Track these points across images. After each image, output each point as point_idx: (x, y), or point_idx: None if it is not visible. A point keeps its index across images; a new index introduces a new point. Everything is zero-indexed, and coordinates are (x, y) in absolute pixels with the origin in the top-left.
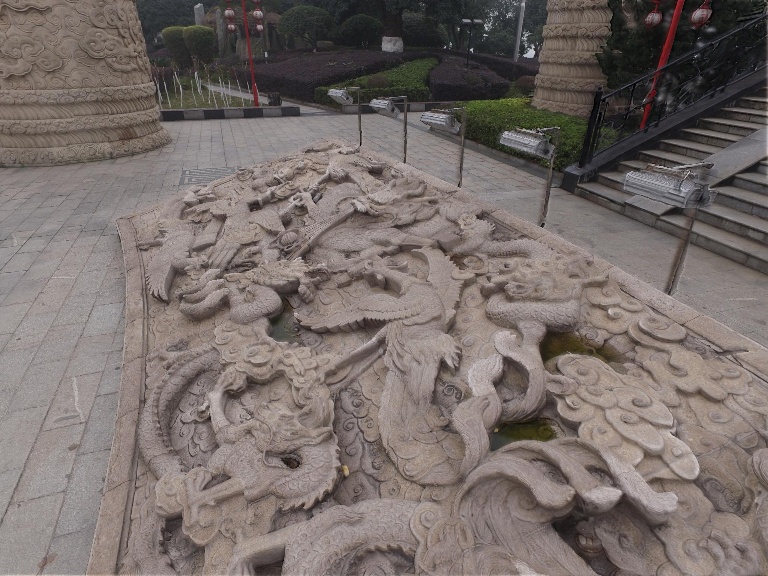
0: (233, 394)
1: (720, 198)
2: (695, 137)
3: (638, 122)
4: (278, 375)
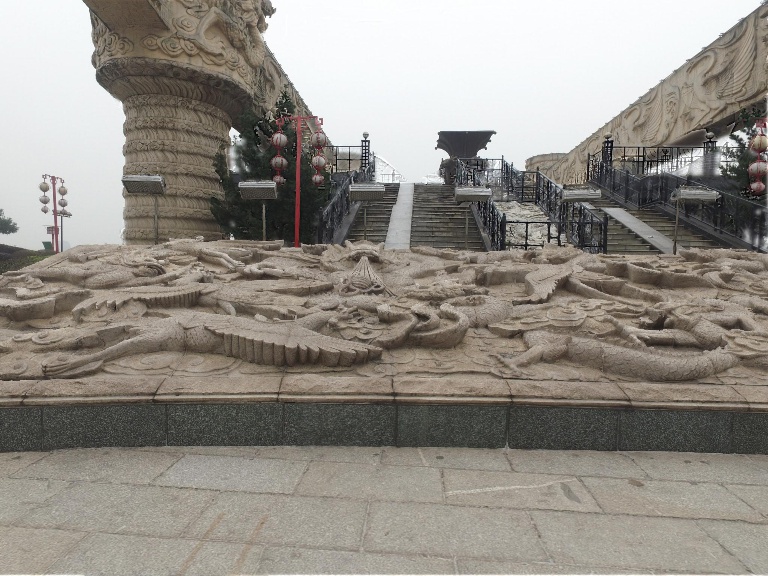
0: None
1: None
2: None
3: None
4: None
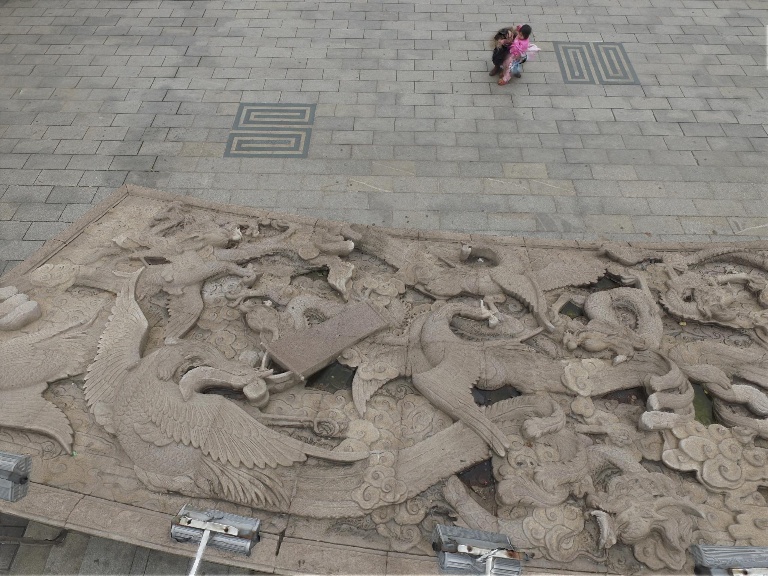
0: (747, 285)
1: None
2: None
3: None
4: (766, 308)
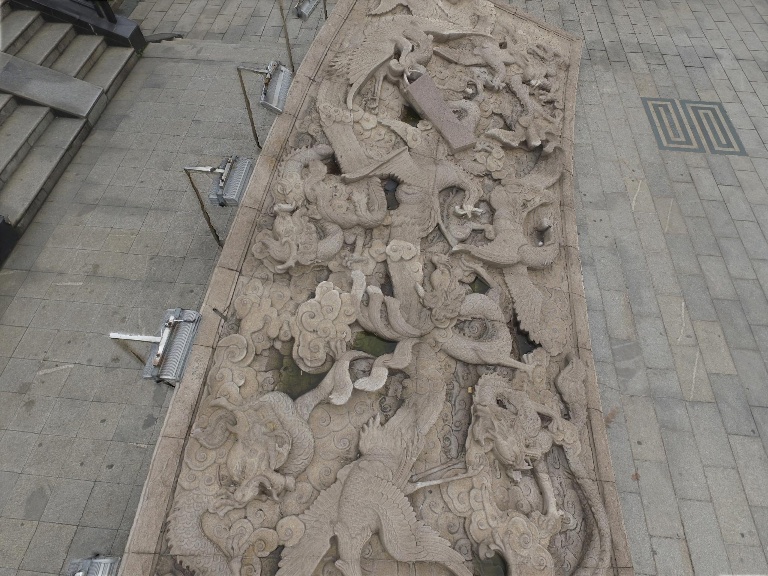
0: None
1: None
2: None
3: None
4: None
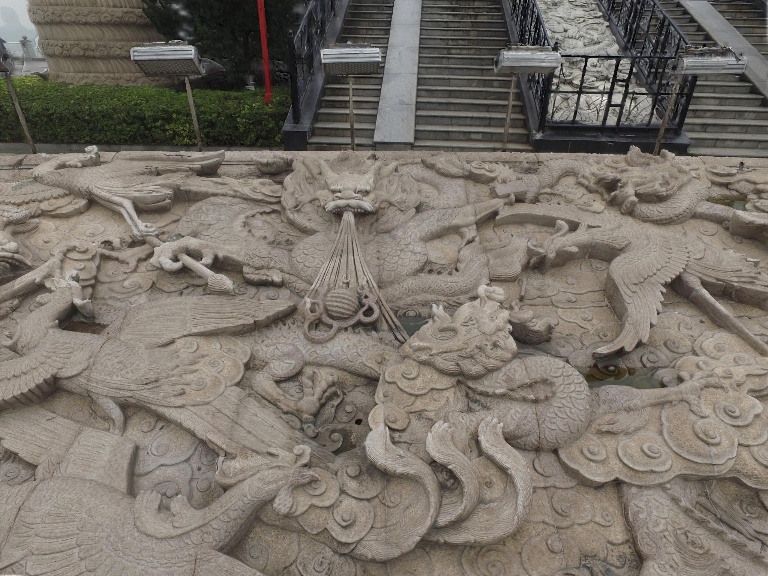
0: None
1: (425, 119)
2: (343, 80)
3: (213, 84)
4: None
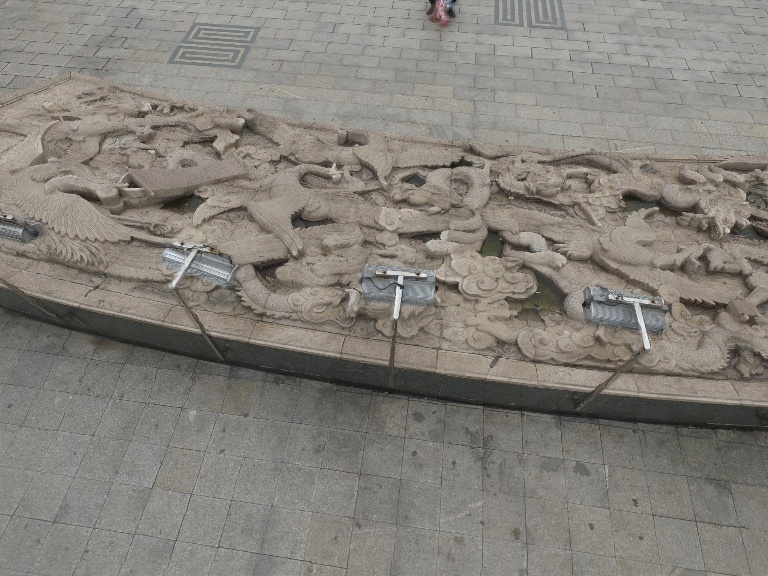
0: None
1: None
2: None
3: None
4: None
